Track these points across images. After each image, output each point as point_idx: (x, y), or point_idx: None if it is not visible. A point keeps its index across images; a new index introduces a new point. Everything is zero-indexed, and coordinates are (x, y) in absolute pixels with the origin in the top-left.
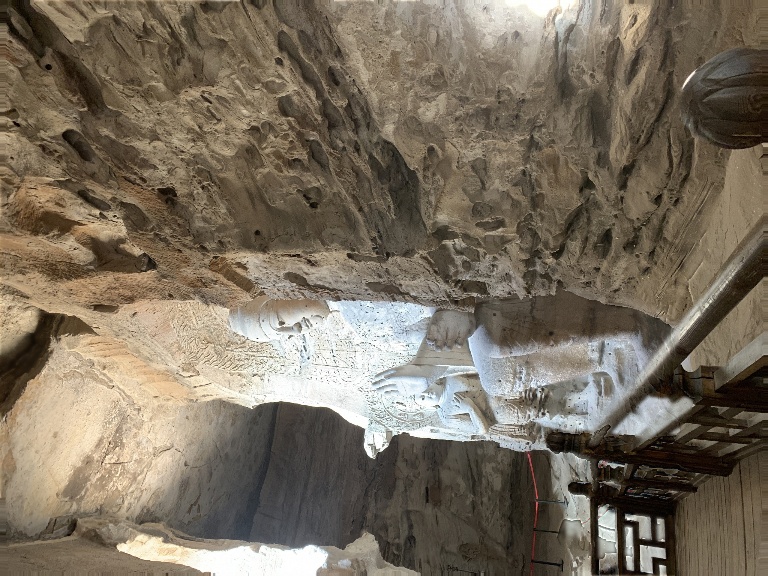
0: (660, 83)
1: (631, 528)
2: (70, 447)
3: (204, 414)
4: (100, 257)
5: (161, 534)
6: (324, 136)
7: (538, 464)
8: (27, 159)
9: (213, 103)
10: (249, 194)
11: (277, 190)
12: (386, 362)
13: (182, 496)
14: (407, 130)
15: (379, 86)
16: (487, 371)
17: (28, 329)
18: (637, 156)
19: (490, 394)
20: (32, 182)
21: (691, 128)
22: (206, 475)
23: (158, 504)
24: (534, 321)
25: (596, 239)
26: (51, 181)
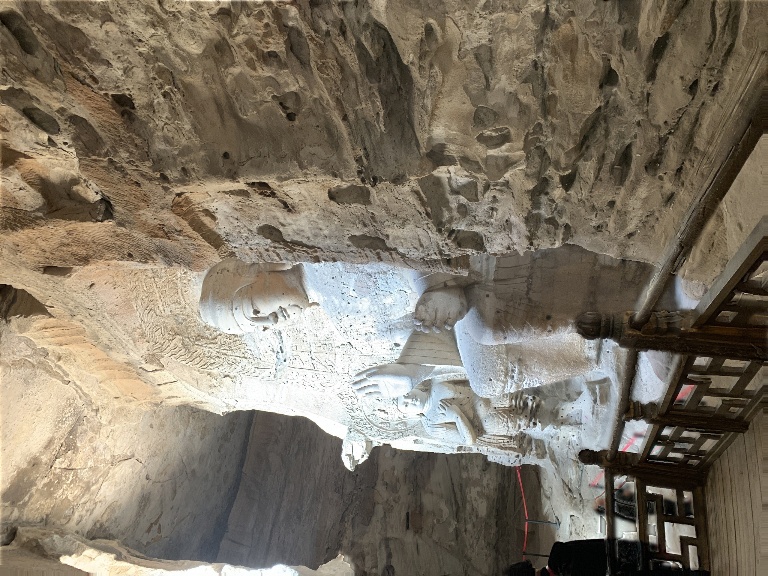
0: None
1: (653, 502)
2: (15, 445)
3: (170, 424)
4: (50, 202)
5: (114, 551)
6: (305, 13)
7: (528, 482)
8: None
9: None
10: (218, 106)
11: (249, 97)
12: (368, 366)
13: (141, 513)
14: None
15: None
16: (477, 369)
17: None
18: (672, 25)
19: (479, 395)
20: None
21: None
22: (169, 492)
23: (113, 519)
24: (530, 303)
25: (614, 157)
26: None
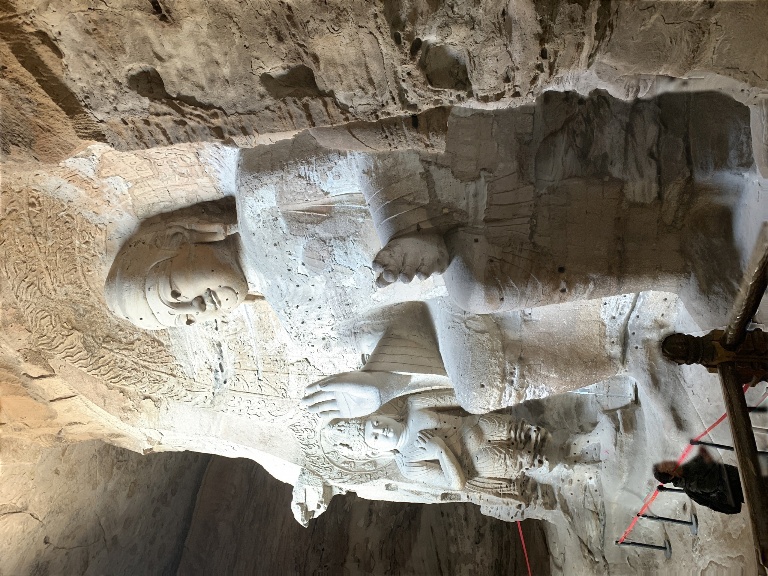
0: None
1: None
2: None
3: (85, 472)
4: None
5: None
6: None
7: (532, 546)
8: None
9: None
10: None
11: None
12: None
13: None
14: None
15: None
16: (464, 372)
17: None
18: None
19: (468, 409)
20: None
21: None
22: (78, 563)
23: None
24: (536, 249)
25: None
26: None
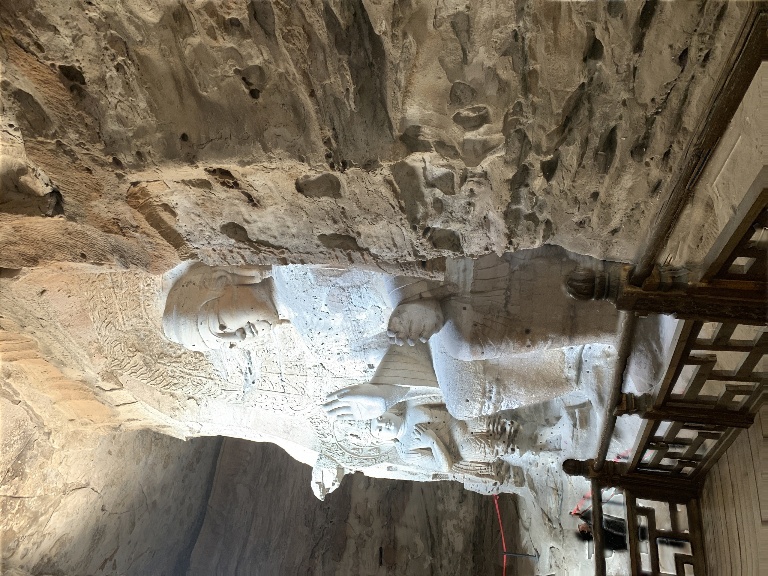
0: None
1: (645, 517)
2: None
3: (131, 451)
4: None
5: None
6: None
7: (505, 512)
8: None
9: None
10: (176, 82)
11: (210, 71)
12: None
13: (95, 547)
14: None
15: None
16: (453, 389)
17: None
18: None
19: (456, 417)
20: None
21: None
22: (127, 525)
23: (63, 553)
24: (509, 316)
25: (598, 141)
26: None
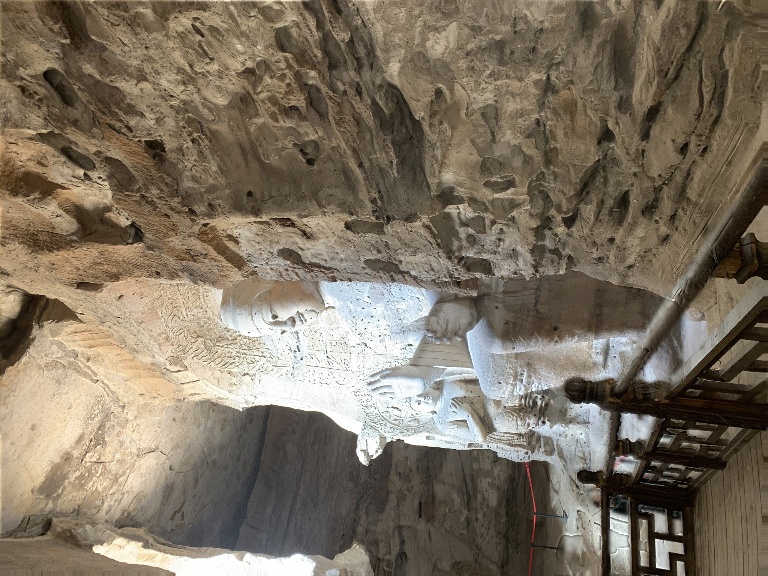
0: (694, 4)
1: (646, 521)
2: (48, 441)
3: (192, 417)
4: (84, 227)
5: (141, 539)
6: (324, 77)
7: (536, 476)
8: (7, 108)
9: (205, 36)
10: (242, 150)
11: (272, 144)
12: (382, 365)
13: (165, 502)
14: (414, 68)
15: (385, 15)
16: (487, 372)
17: (10, 314)
18: (663, 96)
19: None
20: (12, 136)
21: (726, 58)
22: (192, 481)
23: (140, 508)
24: (538, 315)
25: (612, 202)
26: (33, 135)
